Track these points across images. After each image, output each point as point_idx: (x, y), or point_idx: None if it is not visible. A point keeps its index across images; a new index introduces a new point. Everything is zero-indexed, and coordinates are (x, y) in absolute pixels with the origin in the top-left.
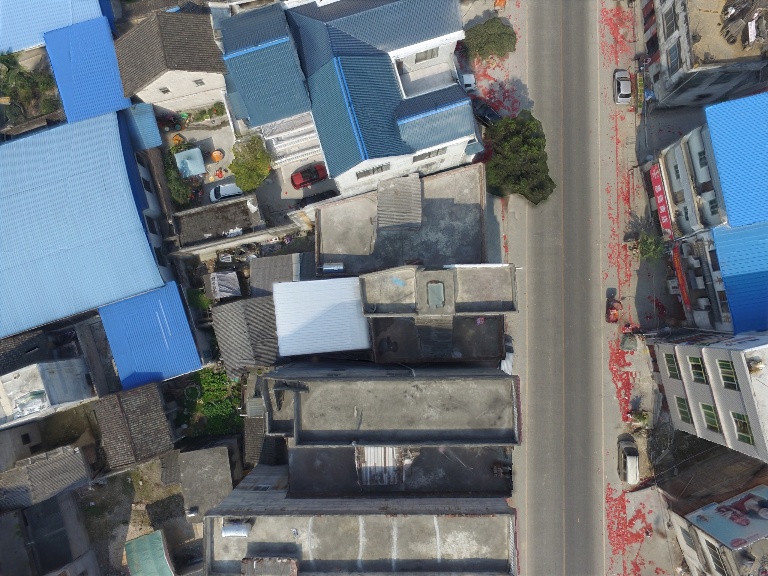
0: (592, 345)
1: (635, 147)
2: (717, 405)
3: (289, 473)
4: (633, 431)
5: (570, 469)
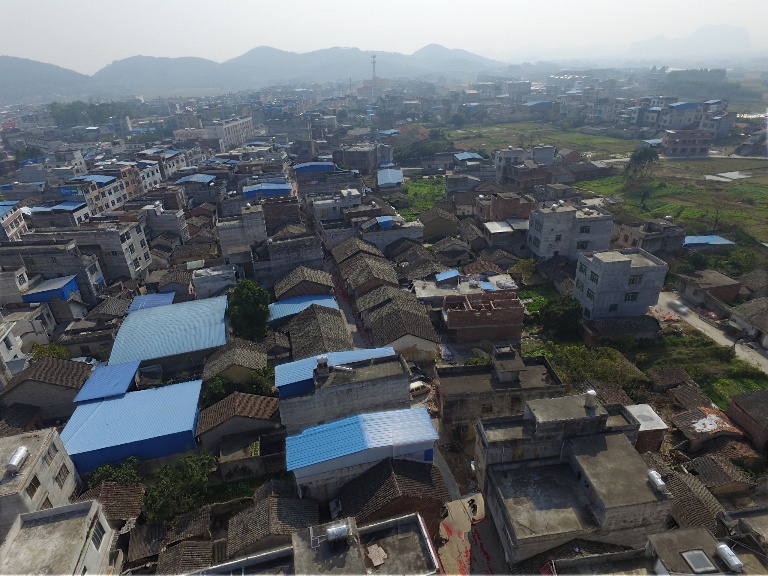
0: None
1: None
2: None
3: (96, 251)
4: None
5: None
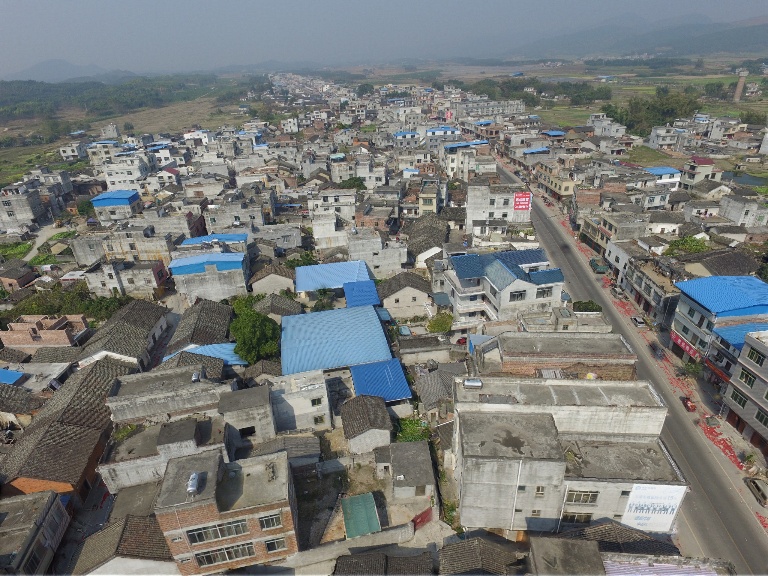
0: (685, 424)
1: (659, 342)
2: (766, 380)
3: None
4: (753, 475)
5: (714, 499)
